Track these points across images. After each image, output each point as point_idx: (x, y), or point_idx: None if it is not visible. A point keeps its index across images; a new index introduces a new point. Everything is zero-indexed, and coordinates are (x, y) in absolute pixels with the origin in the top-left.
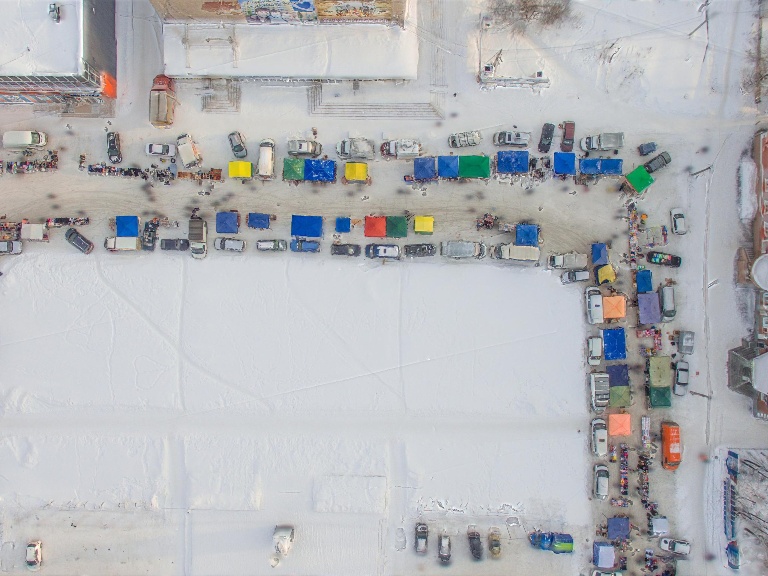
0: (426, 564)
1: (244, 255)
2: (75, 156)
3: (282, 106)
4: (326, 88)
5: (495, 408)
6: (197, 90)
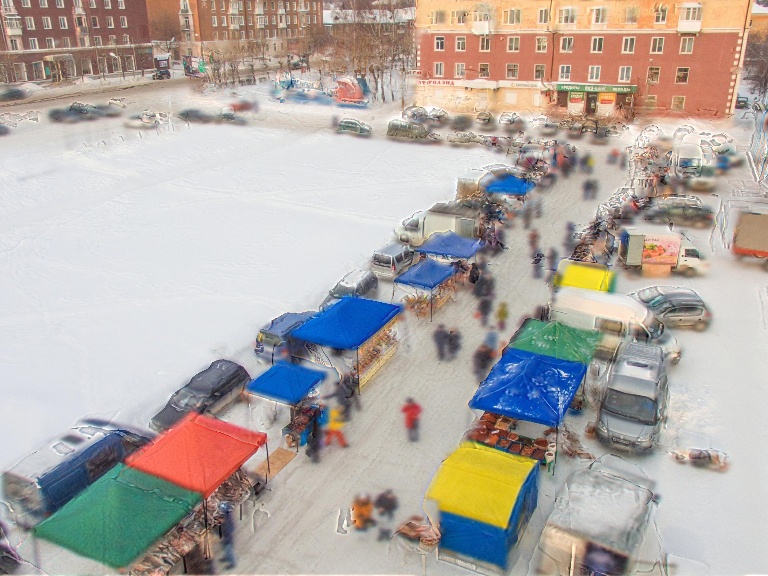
0: None
1: None
2: None
3: None
4: None
5: None
6: None
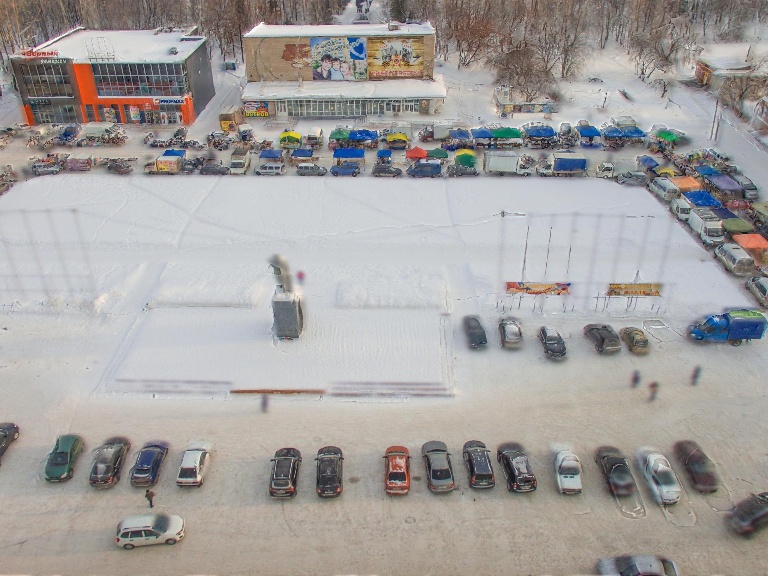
0: (526, 367)
1: None
2: None
3: (333, 125)
4: (371, 116)
5: (580, 243)
6: None
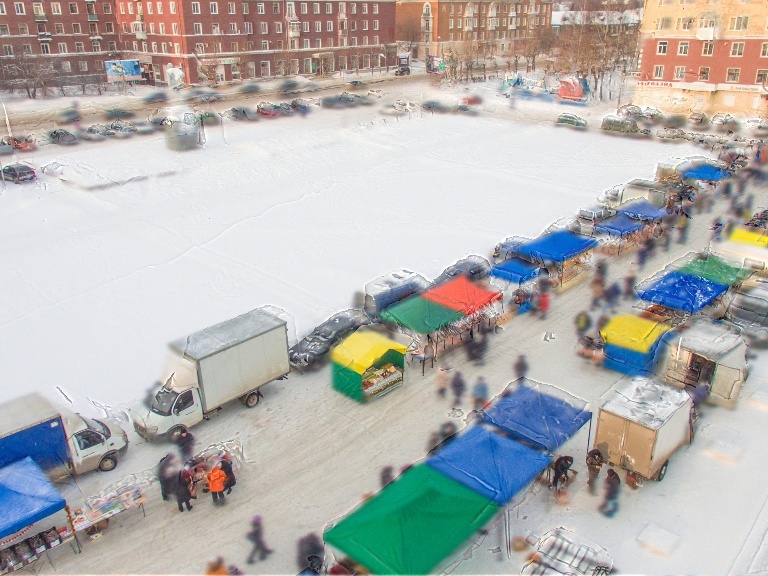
0: None
1: None
2: None
3: None
4: None
5: None
6: None
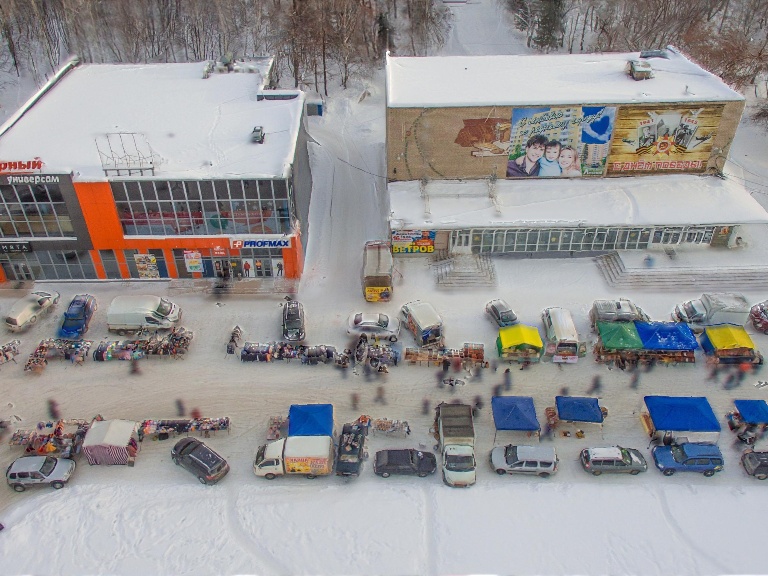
0: None
1: (557, 482)
2: (221, 337)
3: (561, 277)
4: (624, 254)
5: None
6: (427, 262)
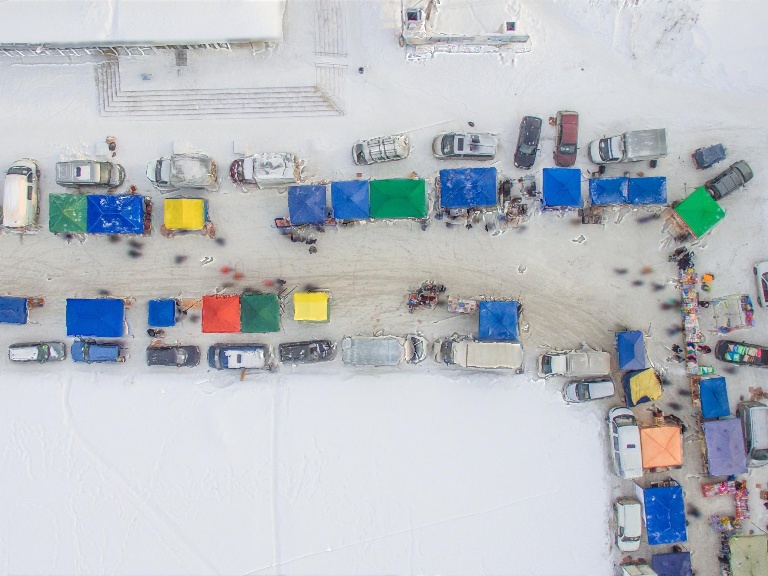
0: None
1: None
2: None
3: (50, 100)
4: (126, 65)
5: None
6: None
